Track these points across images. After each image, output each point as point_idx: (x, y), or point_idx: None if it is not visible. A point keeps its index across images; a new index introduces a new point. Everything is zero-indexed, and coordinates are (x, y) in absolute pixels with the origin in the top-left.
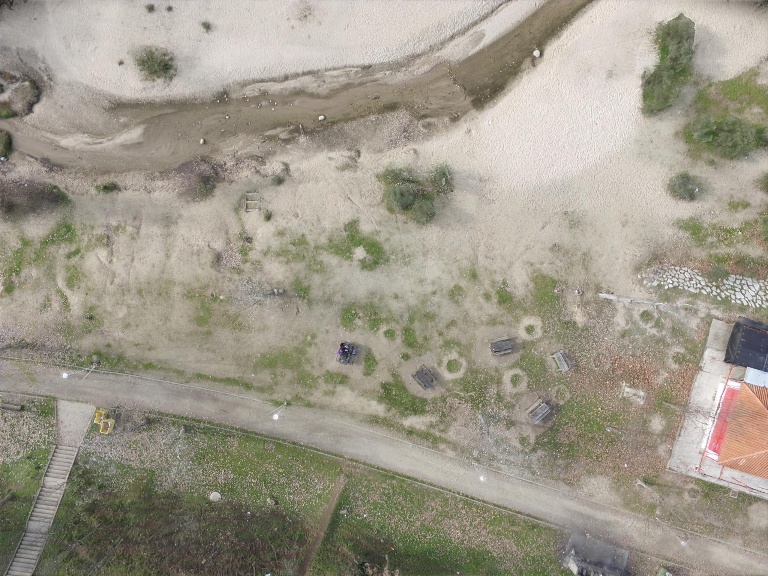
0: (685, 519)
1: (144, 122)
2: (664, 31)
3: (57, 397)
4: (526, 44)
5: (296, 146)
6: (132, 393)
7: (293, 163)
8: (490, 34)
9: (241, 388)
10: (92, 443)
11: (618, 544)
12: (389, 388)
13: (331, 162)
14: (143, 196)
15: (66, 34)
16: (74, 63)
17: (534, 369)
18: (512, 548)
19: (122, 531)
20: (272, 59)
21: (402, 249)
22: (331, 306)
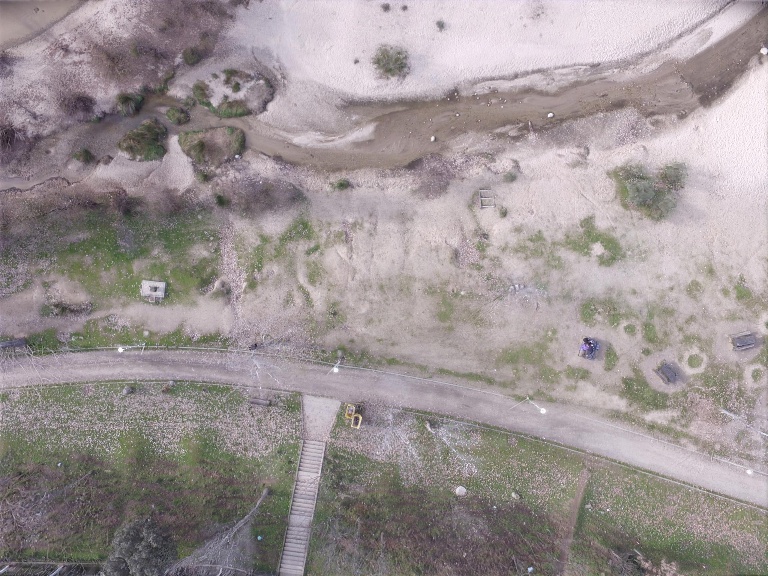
0: None
1: (376, 120)
2: None
3: (303, 392)
4: (753, 42)
5: (525, 143)
6: (376, 388)
7: (522, 160)
8: (718, 32)
9: (484, 383)
10: (338, 438)
11: None
12: (630, 383)
13: (561, 159)
14: (377, 193)
15: (301, 33)
16: (308, 62)
17: None
18: (754, 542)
19: (380, 525)
20: (504, 57)
21: (638, 245)
22: (570, 301)
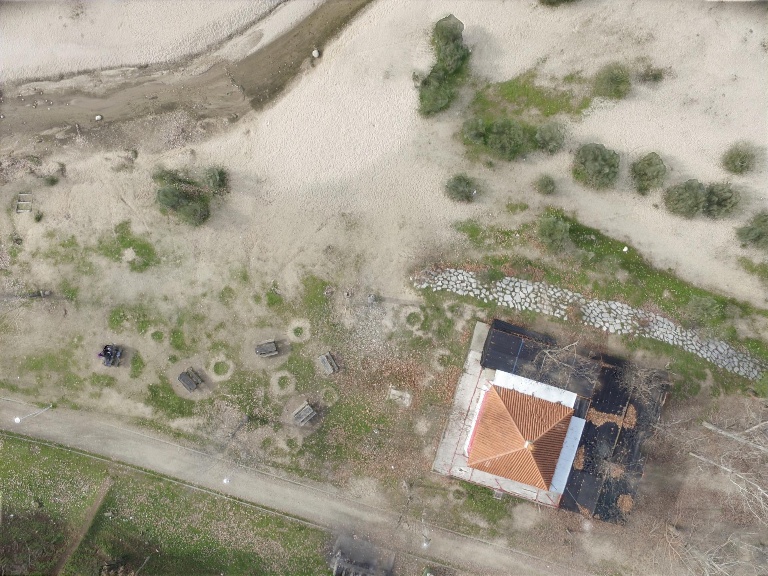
0: (451, 520)
1: None
2: (435, 32)
3: None
4: (305, 44)
5: (73, 146)
6: None
7: (69, 163)
8: (268, 34)
9: (6, 390)
10: None
11: (385, 545)
12: (156, 390)
13: (107, 163)
14: None
15: None
16: None
17: (302, 371)
18: (279, 549)
19: None
20: (45, 58)
21: (173, 251)
22: (99, 308)
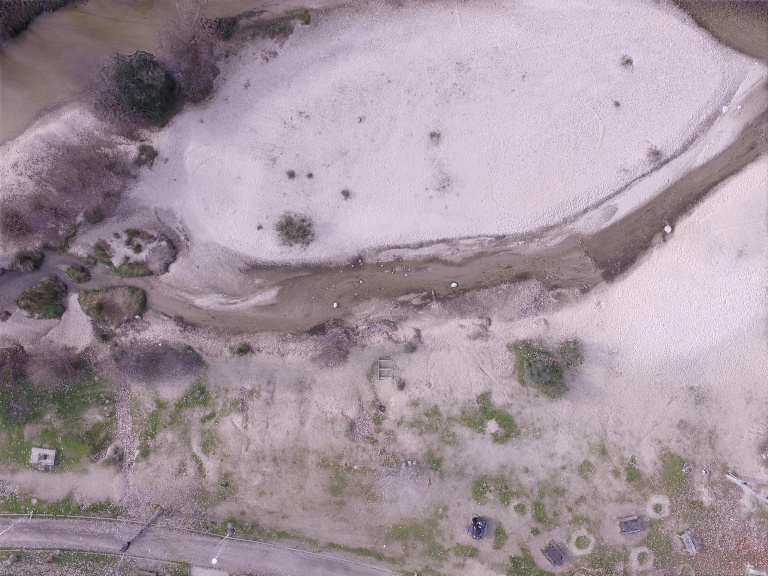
0: None
1: (278, 284)
2: None
3: (191, 563)
4: (657, 219)
5: (428, 312)
6: (265, 561)
7: (424, 329)
8: (623, 208)
9: (372, 558)
10: None
11: None
12: (518, 562)
13: (462, 330)
14: (277, 359)
15: (205, 196)
16: (212, 225)
17: (660, 547)
18: None
19: None
20: (409, 227)
21: (533, 422)
22: (463, 478)
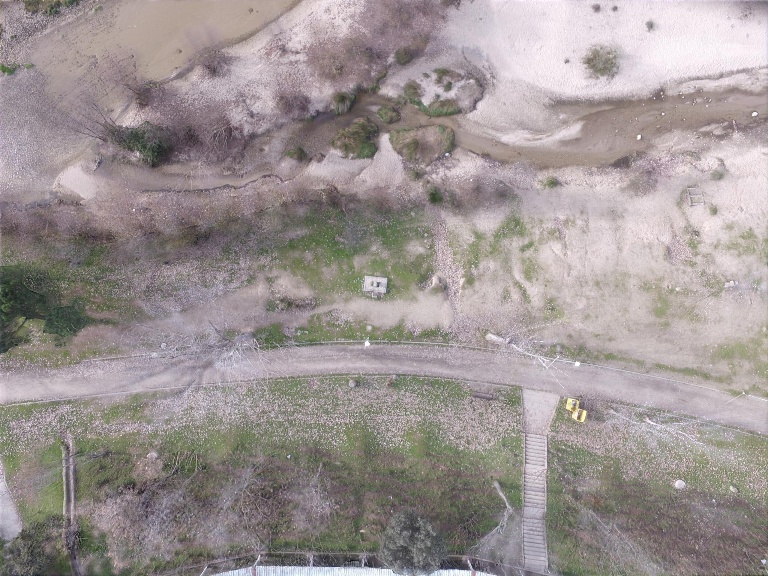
0: None
1: (582, 119)
2: None
3: (522, 386)
4: None
5: (730, 142)
6: (594, 382)
7: (727, 158)
8: None
9: (700, 378)
10: (559, 431)
11: None
12: None
13: (766, 157)
14: (587, 190)
15: (511, 33)
16: (518, 61)
17: None
18: None
19: (610, 517)
20: (711, 57)
21: None
22: None
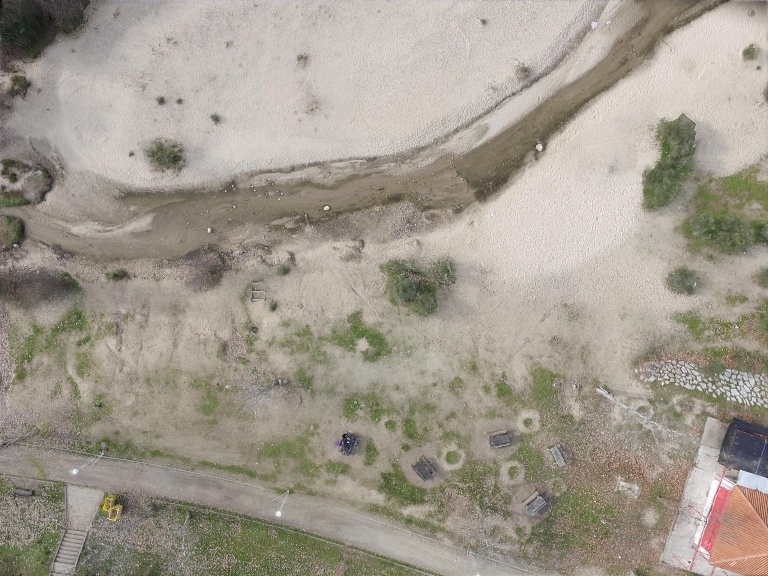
0: None
1: (153, 211)
2: (665, 131)
3: (67, 482)
4: (529, 138)
5: (301, 236)
6: (139, 479)
7: (298, 252)
8: (493, 128)
9: (245, 476)
10: (100, 528)
11: None
12: (389, 478)
13: (335, 252)
14: (152, 284)
15: (78, 125)
16: (85, 153)
17: (531, 461)
18: None
19: None
20: (279, 151)
21: (404, 341)
22: (334, 396)
